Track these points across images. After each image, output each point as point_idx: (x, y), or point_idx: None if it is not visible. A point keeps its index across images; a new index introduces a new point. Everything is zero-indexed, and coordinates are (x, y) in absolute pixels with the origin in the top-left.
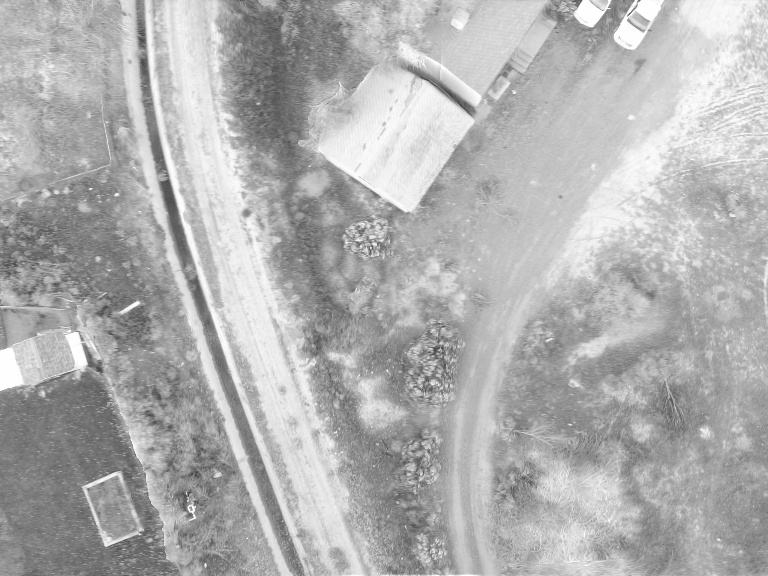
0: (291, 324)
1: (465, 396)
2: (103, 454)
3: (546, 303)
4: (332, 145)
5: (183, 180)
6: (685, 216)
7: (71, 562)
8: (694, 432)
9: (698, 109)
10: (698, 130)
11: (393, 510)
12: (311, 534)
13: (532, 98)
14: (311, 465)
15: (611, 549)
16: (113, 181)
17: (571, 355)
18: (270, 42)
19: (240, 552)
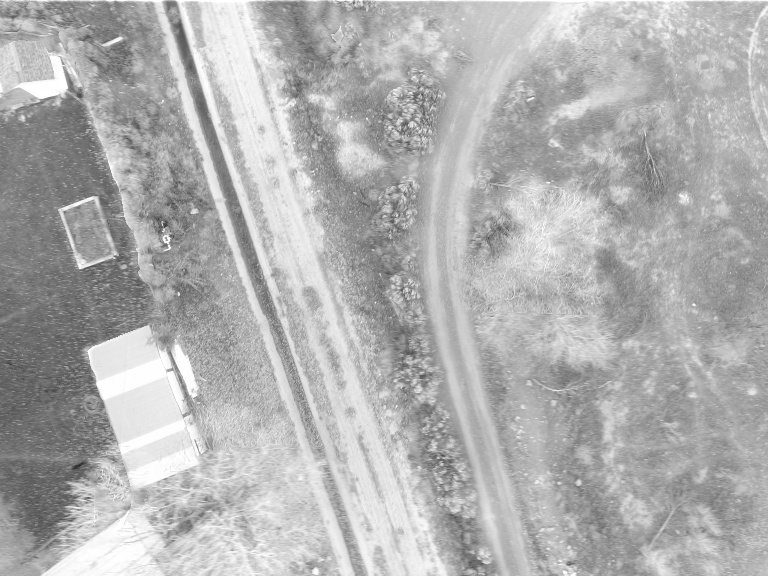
0: (272, 64)
1: (444, 150)
2: (80, 179)
3: (529, 64)
4: None
5: None
6: None
7: (45, 283)
8: (673, 197)
9: None
10: None
11: (368, 256)
12: (285, 273)
13: None
14: (287, 204)
15: (585, 305)
16: None
17: (552, 116)
18: None
19: (214, 287)
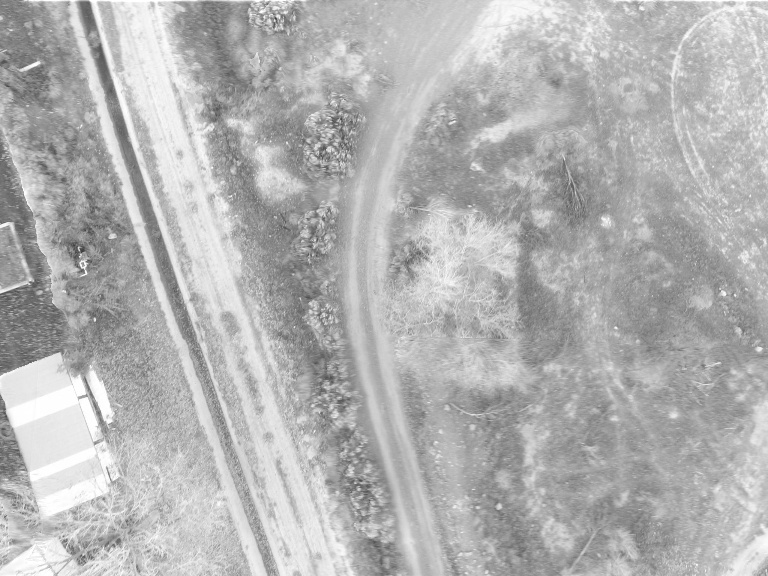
0: (190, 89)
1: (365, 174)
2: None
3: (451, 87)
4: None
5: None
6: (594, 8)
7: None
8: (595, 220)
9: None
10: None
11: (288, 280)
12: (204, 298)
13: None
14: (206, 229)
15: (505, 328)
16: None
17: (474, 139)
18: None
19: (132, 312)
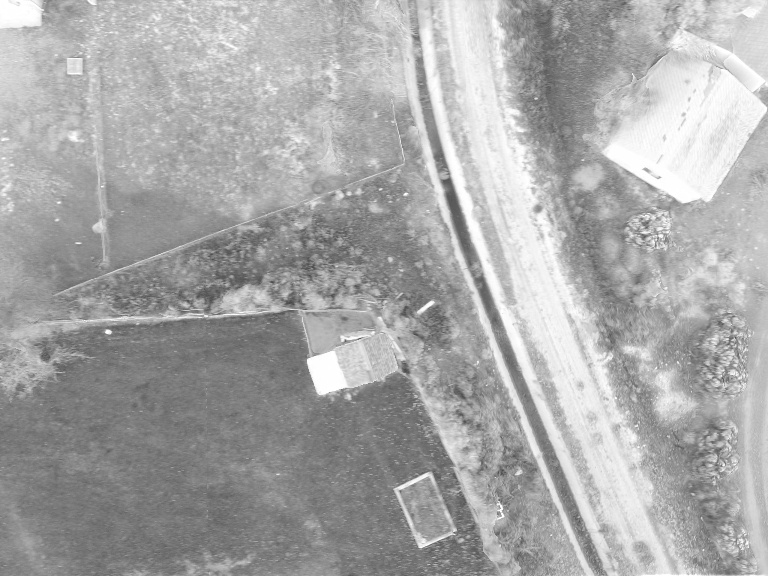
0: (586, 319)
1: (752, 385)
2: (412, 455)
3: None
4: (628, 137)
5: (470, 177)
6: None
7: (386, 565)
8: None
9: None
10: None
11: (691, 502)
12: (614, 529)
13: None
14: (612, 459)
15: None
16: (401, 181)
17: None
18: (539, 36)
19: (546, 549)
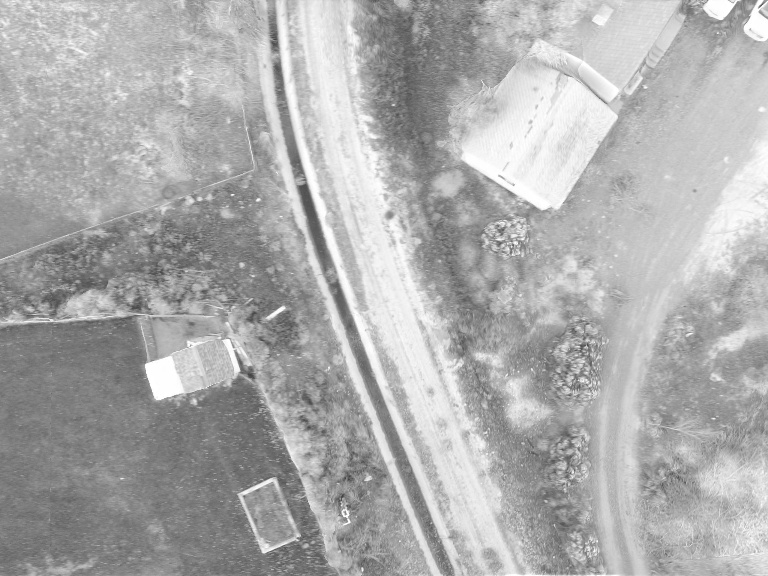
0: (437, 325)
1: (608, 393)
2: (257, 461)
3: (684, 297)
4: (477, 145)
5: (323, 184)
6: None
7: (229, 570)
8: None
9: None
10: None
11: (543, 509)
12: (463, 535)
13: (663, 92)
14: (461, 466)
15: (760, 542)
16: (254, 186)
17: (711, 349)
18: (400, 43)
19: (394, 555)
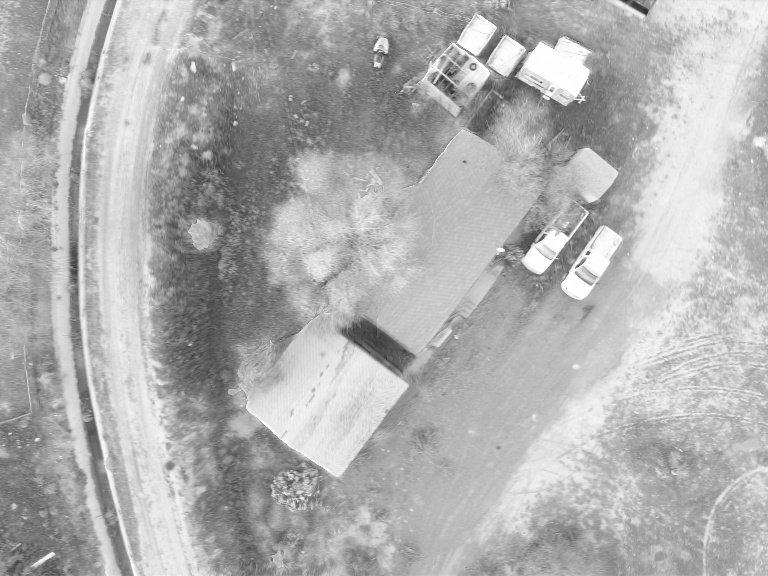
0: None
1: None
2: None
3: (478, 558)
4: (260, 406)
5: (107, 426)
6: (626, 472)
7: None
8: None
9: (645, 359)
10: (644, 381)
11: None
12: None
13: (475, 343)
14: None
15: None
16: (34, 425)
17: None
18: (207, 276)
19: None
